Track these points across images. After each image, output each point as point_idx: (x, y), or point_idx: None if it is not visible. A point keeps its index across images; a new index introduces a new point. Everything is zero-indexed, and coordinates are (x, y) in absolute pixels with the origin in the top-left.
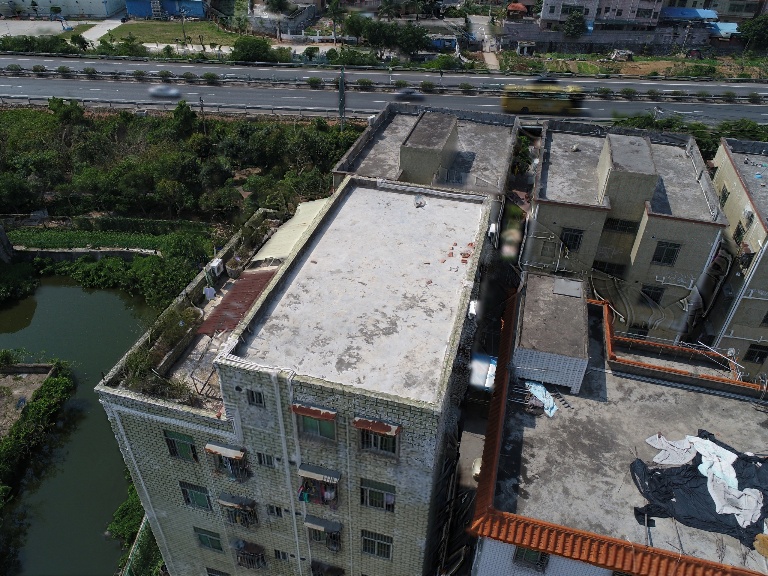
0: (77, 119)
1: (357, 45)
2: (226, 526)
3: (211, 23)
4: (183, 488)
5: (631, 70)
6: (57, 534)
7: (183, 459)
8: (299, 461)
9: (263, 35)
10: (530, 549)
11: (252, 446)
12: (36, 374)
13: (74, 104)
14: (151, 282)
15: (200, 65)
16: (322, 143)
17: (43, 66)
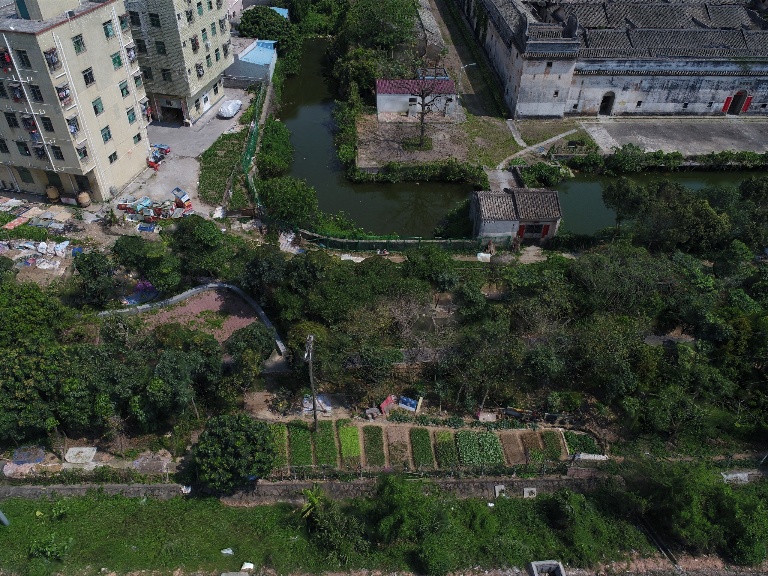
0: None
1: None
2: None
3: None
4: None
5: None
6: None
7: None
8: None
9: None
10: None
11: None
12: None
13: None
14: None
15: None
16: None
17: None
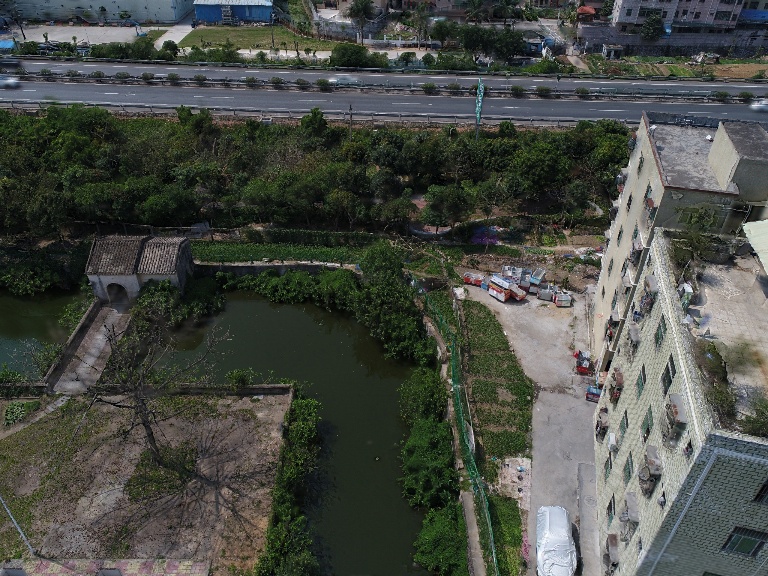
0: (209, 128)
1: (441, 49)
2: (758, 572)
3: (283, 28)
4: (732, 534)
5: (724, 73)
6: (362, 567)
7: None
8: None
9: (344, 40)
10: None
11: None
12: (272, 395)
13: (206, 112)
14: (364, 297)
15: (302, 71)
16: (476, 151)
17: (152, 73)
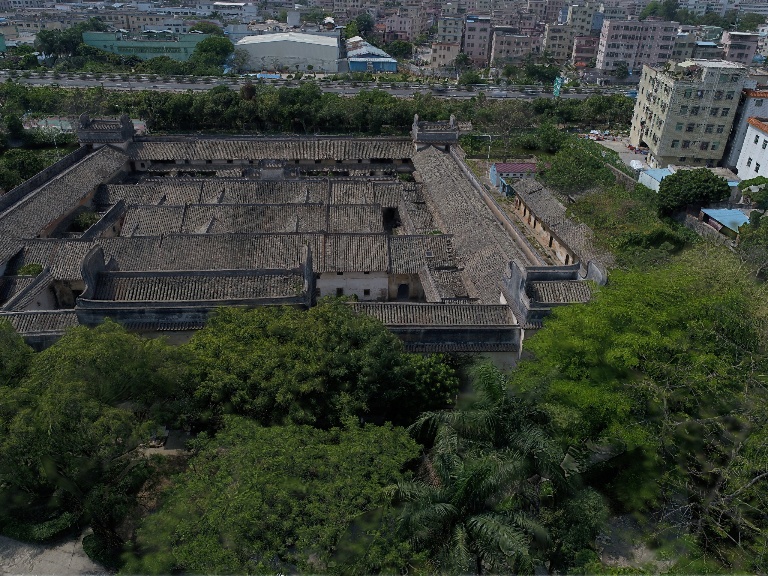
0: None
1: None
2: (687, 119)
3: None
4: (681, 108)
5: None
6: None
7: (686, 97)
8: (715, 90)
9: None
10: (759, 100)
11: (706, 88)
12: None
13: None
14: None
15: None
16: (564, 103)
17: None
